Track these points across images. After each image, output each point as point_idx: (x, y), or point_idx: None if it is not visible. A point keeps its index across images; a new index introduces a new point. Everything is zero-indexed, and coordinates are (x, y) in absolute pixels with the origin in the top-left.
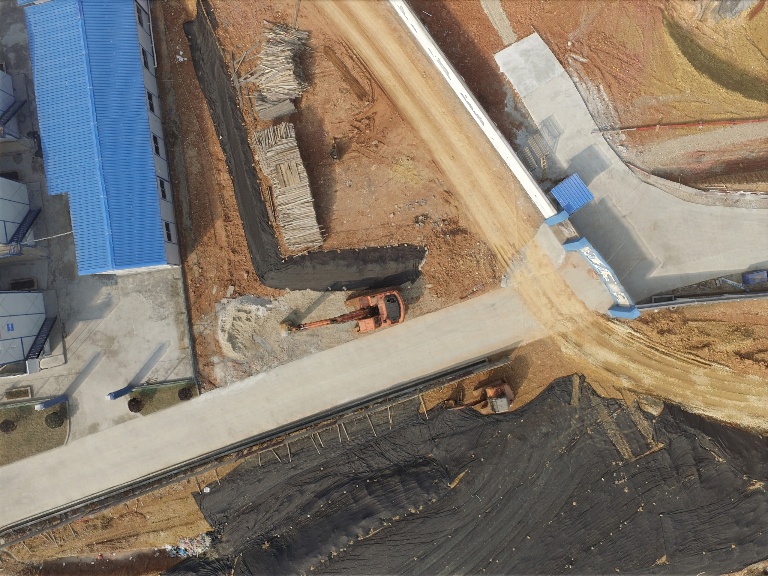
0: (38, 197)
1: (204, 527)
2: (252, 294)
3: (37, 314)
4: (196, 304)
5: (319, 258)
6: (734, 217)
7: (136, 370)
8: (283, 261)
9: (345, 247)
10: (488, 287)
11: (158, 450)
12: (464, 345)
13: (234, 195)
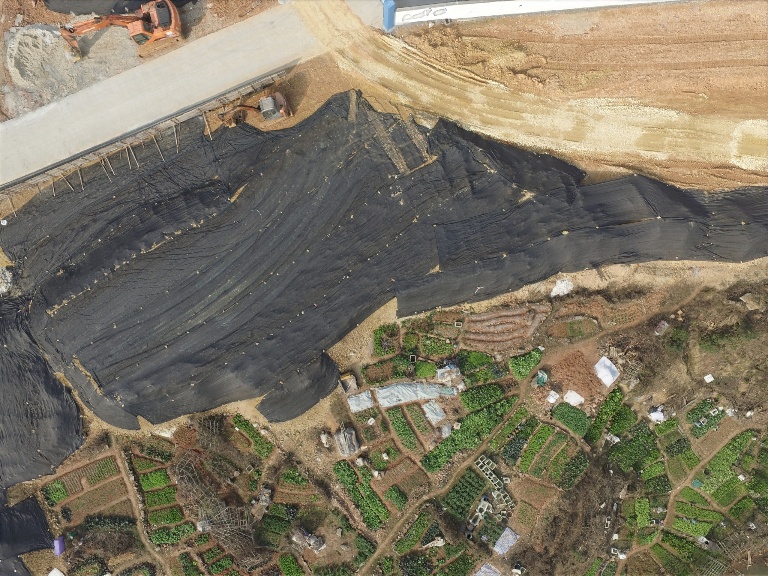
0: None
1: (3, 260)
2: (40, 22)
3: None
4: None
5: None
6: None
7: None
8: None
9: None
10: (266, 4)
11: None
12: (245, 65)
13: None
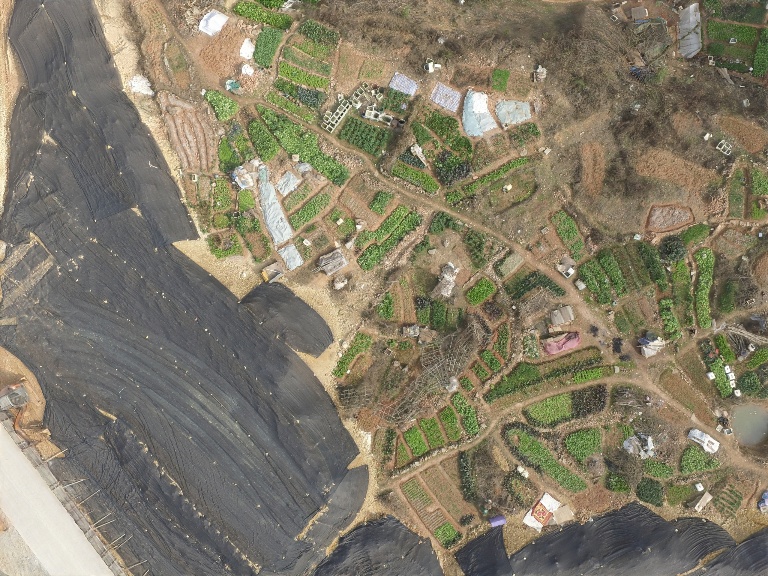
0: None
1: None
2: None
3: None
4: None
5: None
6: None
7: None
8: None
9: None
10: None
11: None
12: None
13: None
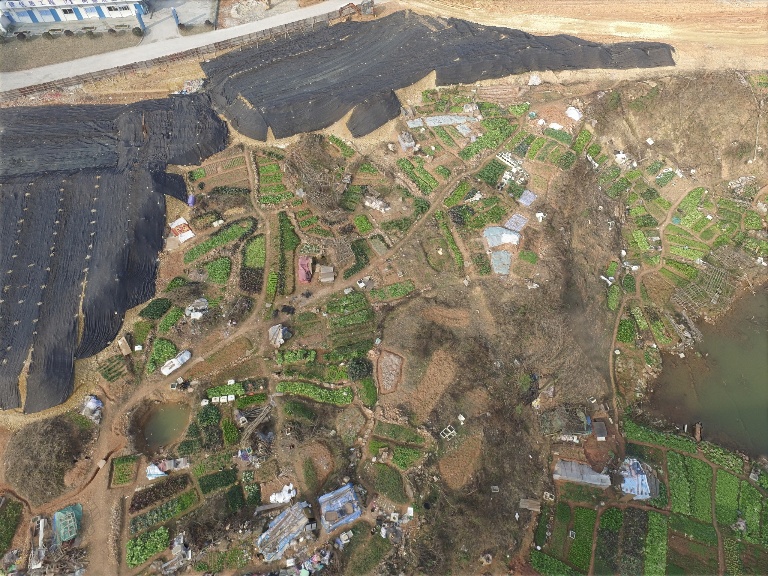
0: None
1: (202, 75)
2: None
3: None
4: None
5: None
6: None
7: (185, 21)
8: None
9: None
10: None
11: (186, 48)
12: None
13: None
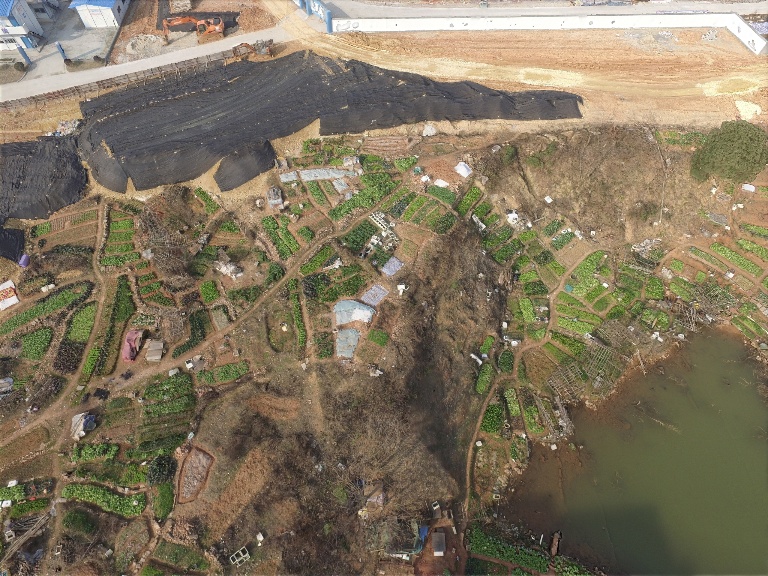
0: (62, 7)
1: (78, 115)
2: None
3: (37, 32)
4: (121, 38)
5: (188, 14)
6: (390, 8)
7: (76, 56)
8: (170, 14)
9: (202, 11)
10: (269, 26)
11: (70, 85)
12: None
13: (157, 11)
